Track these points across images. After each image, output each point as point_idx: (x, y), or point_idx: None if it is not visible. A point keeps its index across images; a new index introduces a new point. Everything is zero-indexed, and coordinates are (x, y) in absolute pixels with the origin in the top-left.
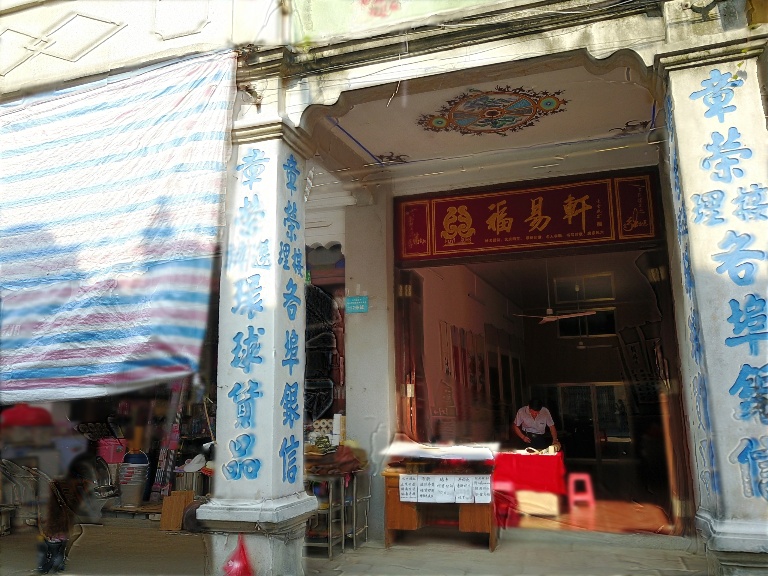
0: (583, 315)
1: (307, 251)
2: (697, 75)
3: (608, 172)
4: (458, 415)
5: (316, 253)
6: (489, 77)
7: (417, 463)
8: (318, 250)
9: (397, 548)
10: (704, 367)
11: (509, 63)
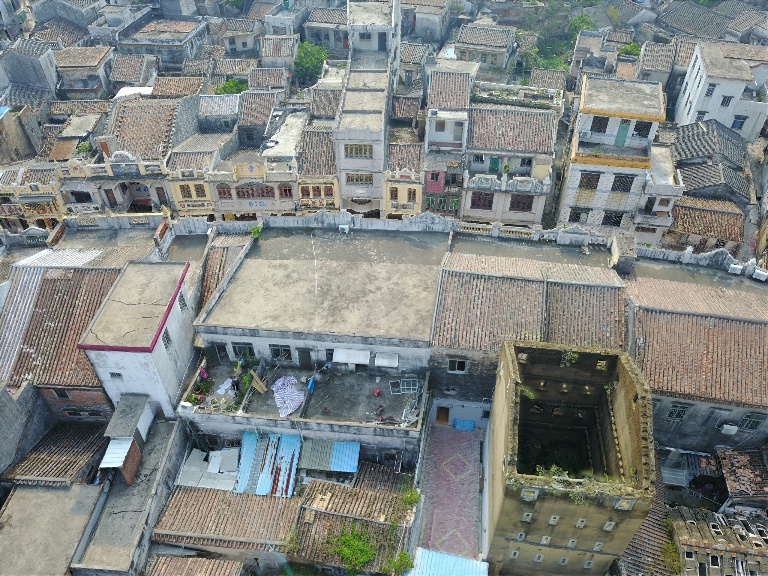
0: None
1: None
2: None
3: None
4: None
5: None
6: None
7: None
8: None
9: None
10: None
11: None
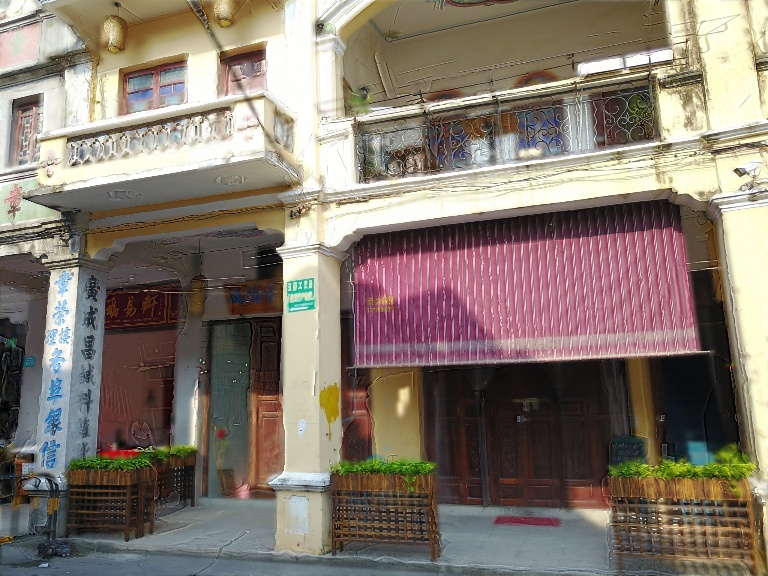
0: (162, 366)
1: (15, 326)
2: (58, 273)
3: (174, 280)
4: (102, 428)
5: (20, 327)
6: (6, 259)
7: (31, 457)
8: (20, 325)
9: (19, 505)
10: (39, 410)
11: (5, 256)
